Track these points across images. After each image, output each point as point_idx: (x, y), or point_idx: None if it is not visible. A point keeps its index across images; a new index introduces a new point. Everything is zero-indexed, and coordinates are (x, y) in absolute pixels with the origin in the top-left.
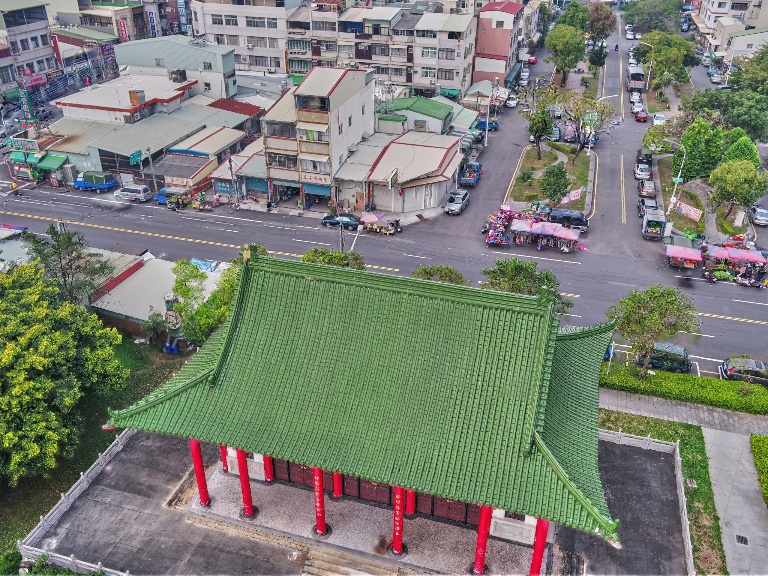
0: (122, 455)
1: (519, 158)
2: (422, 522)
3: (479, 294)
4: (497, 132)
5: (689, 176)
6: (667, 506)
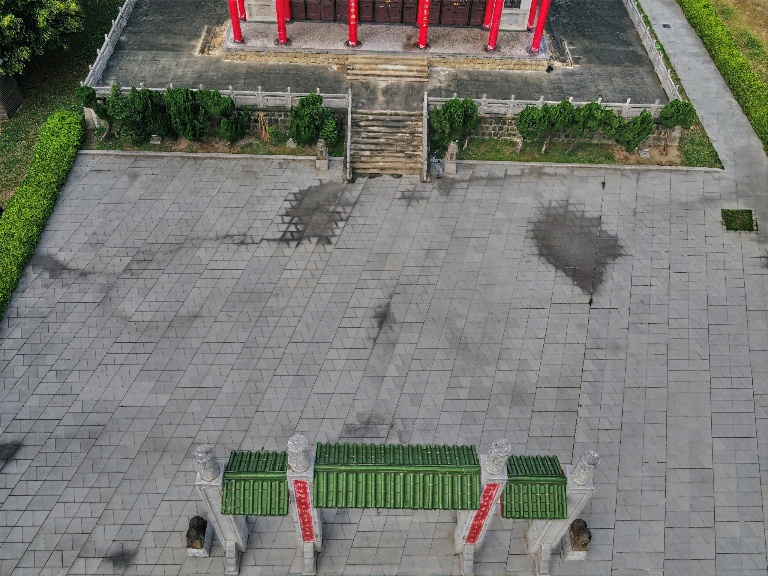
0: (130, 28)
1: None
2: (433, 29)
3: None
4: None
5: None
6: (614, 4)
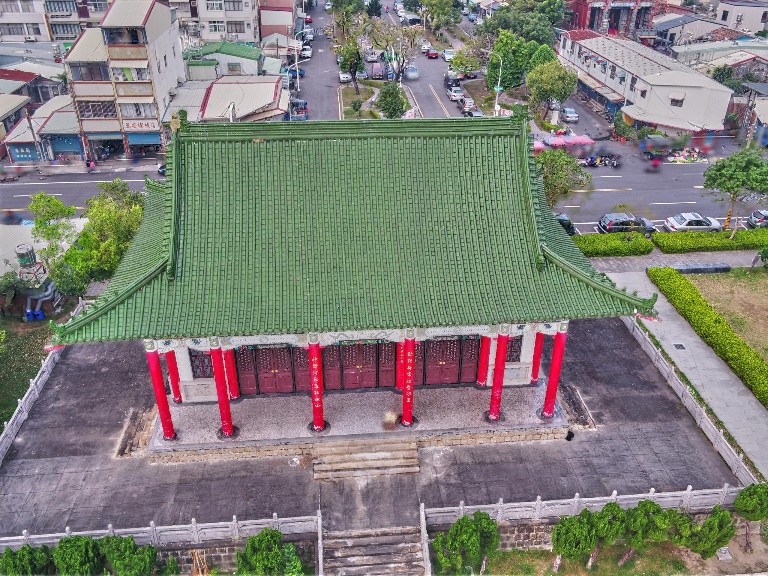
0: (31, 423)
1: (337, 96)
2: (418, 393)
3: (452, 124)
4: (304, 78)
5: (504, 86)
6: (618, 330)
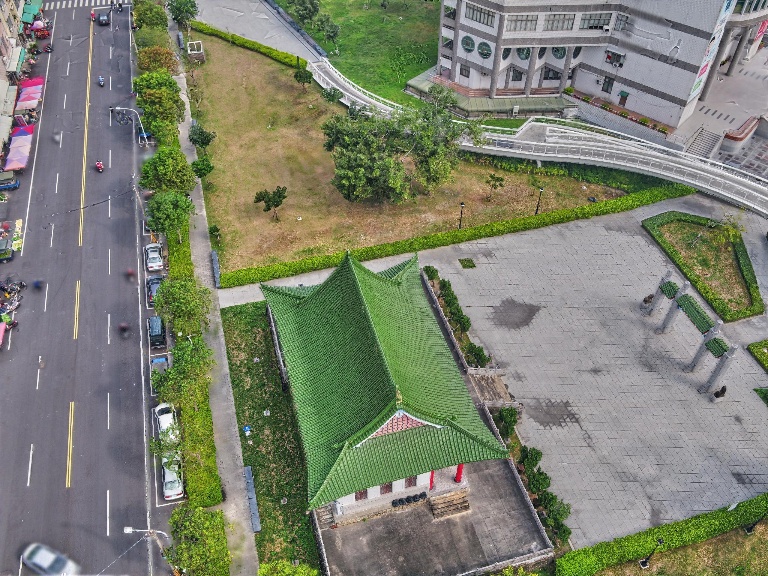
0: None
1: None
2: None
3: None
4: None
5: None
6: None
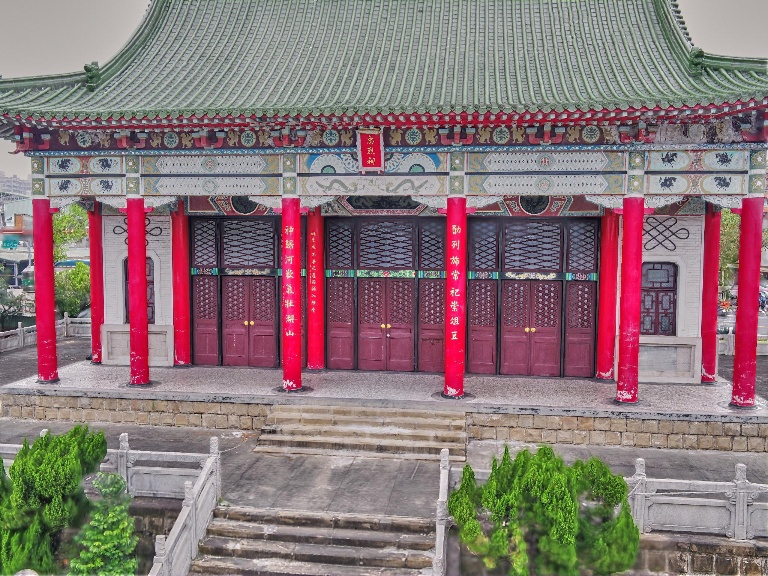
0: None
1: None
2: (484, 378)
3: None
4: None
5: None
6: None
